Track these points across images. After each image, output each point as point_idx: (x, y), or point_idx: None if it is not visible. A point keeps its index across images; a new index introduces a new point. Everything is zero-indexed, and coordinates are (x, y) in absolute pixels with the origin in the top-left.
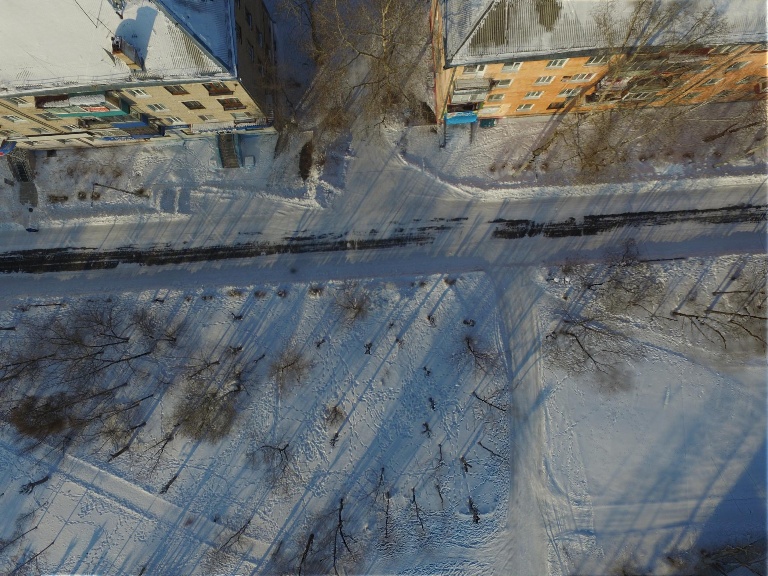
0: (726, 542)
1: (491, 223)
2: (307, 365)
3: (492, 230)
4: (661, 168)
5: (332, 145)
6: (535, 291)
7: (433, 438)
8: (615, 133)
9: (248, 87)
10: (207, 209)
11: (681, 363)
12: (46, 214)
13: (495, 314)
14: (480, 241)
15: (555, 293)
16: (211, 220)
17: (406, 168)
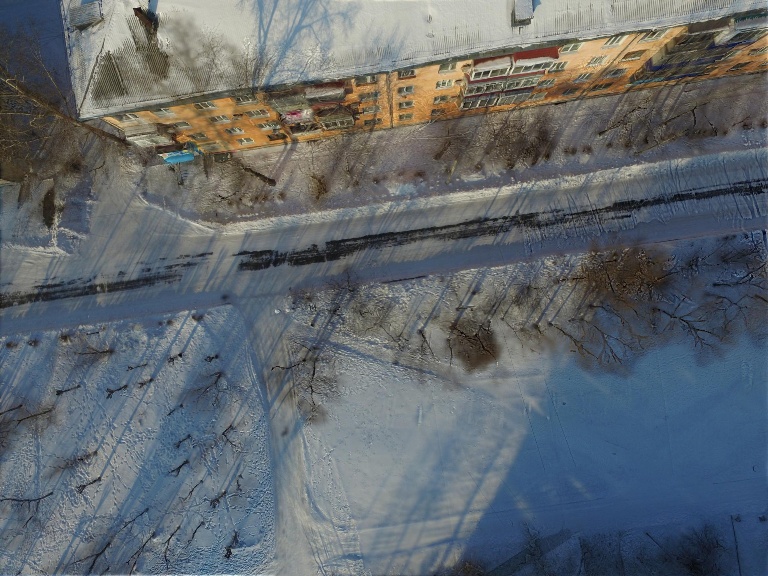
0: (490, 555)
1: (236, 256)
2: (64, 412)
3: (237, 263)
4: (393, 189)
5: (73, 191)
6: (283, 320)
7: (194, 475)
8: (348, 158)
9: None
10: None
11: (431, 381)
12: None
13: (246, 346)
14: (226, 275)
15: (303, 321)
16: None
17: (148, 208)
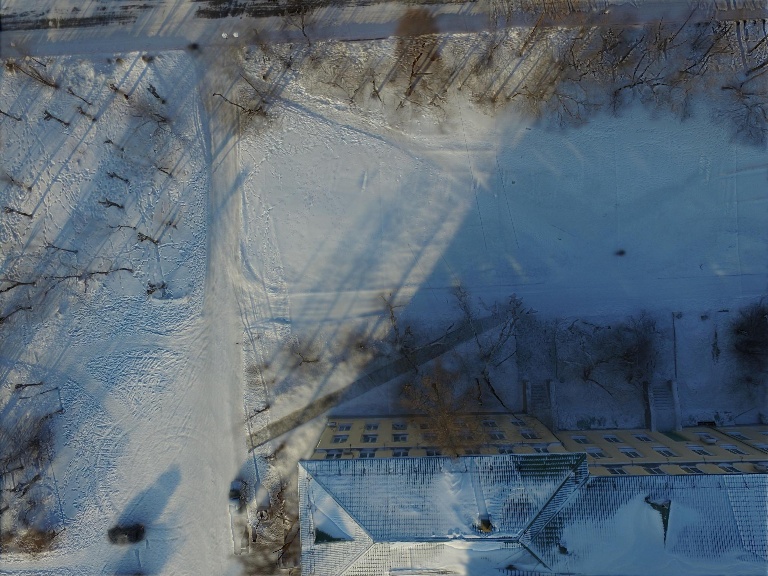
0: (421, 331)
1: (194, 2)
2: (2, 144)
3: (195, 9)
4: None
5: None
6: (235, 71)
7: (128, 221)
8: None
9: None
10: None
11: (379, 146)
12: None
13: (195, 95)
14: (182, 20)
15: (255, 73)
16: None
17: None
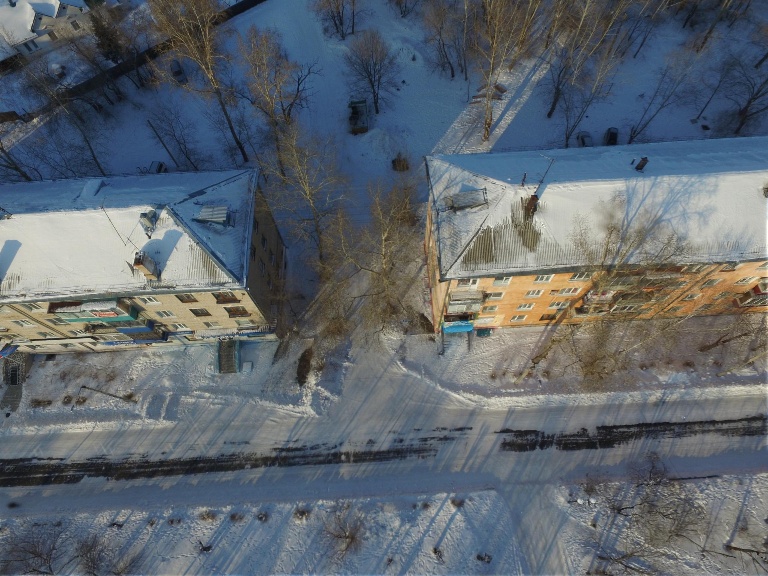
0: None
1: (498, 434)
2: None
3: (499, 441)
4: (665, 377)
5: (331, 352)
6: (557, 516)
7: None
8: (610, 343)
9: (255, 297)
10: (195, 416)
11: None
12: (23, 420)
13: (514, 546)
14: (488, 454)
15: (581, 519)
16: (197, 428)
17: (405, 375)
